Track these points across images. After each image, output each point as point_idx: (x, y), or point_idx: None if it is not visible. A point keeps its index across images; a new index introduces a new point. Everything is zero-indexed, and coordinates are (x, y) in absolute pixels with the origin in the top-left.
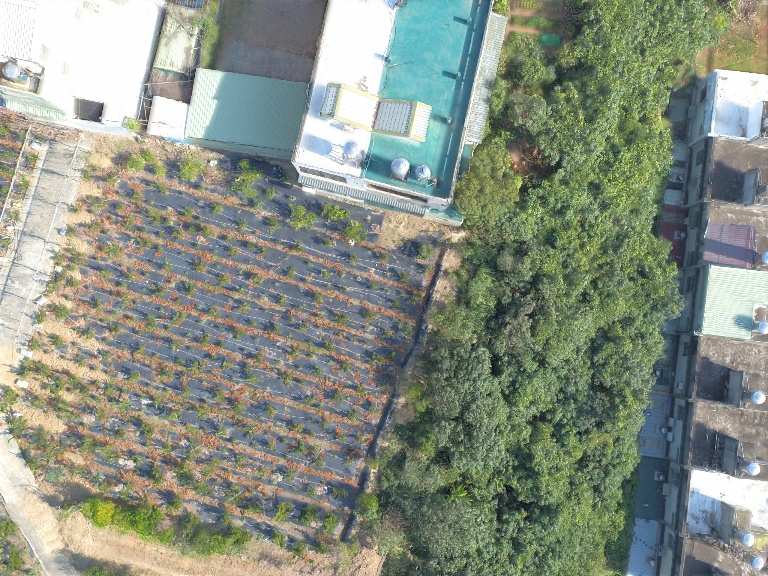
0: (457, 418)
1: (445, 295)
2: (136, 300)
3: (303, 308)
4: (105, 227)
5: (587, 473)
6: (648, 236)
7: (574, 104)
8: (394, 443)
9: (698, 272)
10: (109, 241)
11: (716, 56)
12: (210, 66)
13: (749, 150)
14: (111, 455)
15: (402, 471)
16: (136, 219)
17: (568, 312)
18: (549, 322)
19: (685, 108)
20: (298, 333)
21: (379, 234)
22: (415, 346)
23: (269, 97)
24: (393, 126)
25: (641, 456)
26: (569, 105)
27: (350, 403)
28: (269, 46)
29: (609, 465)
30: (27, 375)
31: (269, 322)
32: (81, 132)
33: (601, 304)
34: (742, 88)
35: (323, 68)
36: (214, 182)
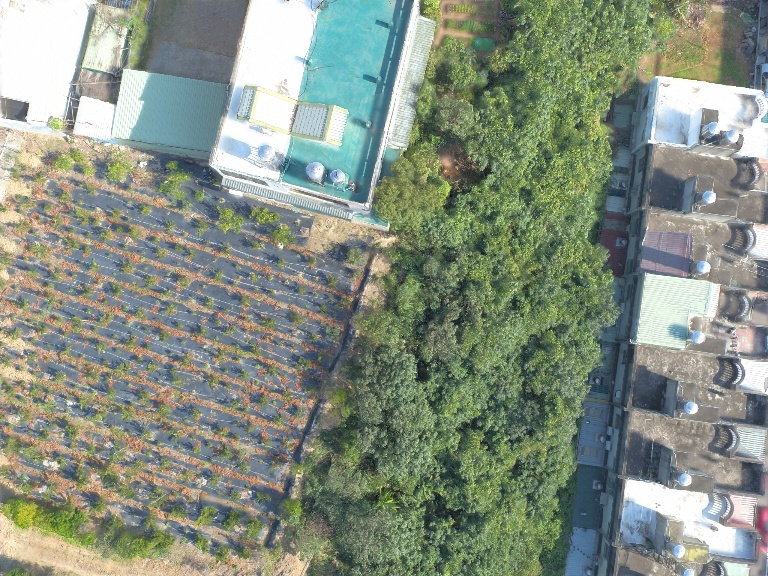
0: (382, 424)
1: (371, 300)
2: (63, 301)
3: (230, 311)
4: (34, 227)
5: (521, 481)
6: (584, 243)
7: (504, 109)
8: (318, 448)
9: (636, 280)
10: (37, 241)
11: (664, 62)
12: (141, 67)
13: (690, 158)
14: (35, 456)
15: (327, 477)
16: (65, 219)
17: (497, 319)
18: (475, 329)
19: (630, 114)
20: (225, 336)
21: (308, 238)
22: (342, 351)
23: (196, 99)
24: (310, 130)
25: (580, 464)
26: (499, 110)
27: (276, 407)
28: (201, 47)
29: (543, 473)
30: None
31: (196, 325)
32: (12, 132)
33: (532, 311)
34: (684, 95)
35: (244, 70)
36: (144, 183)
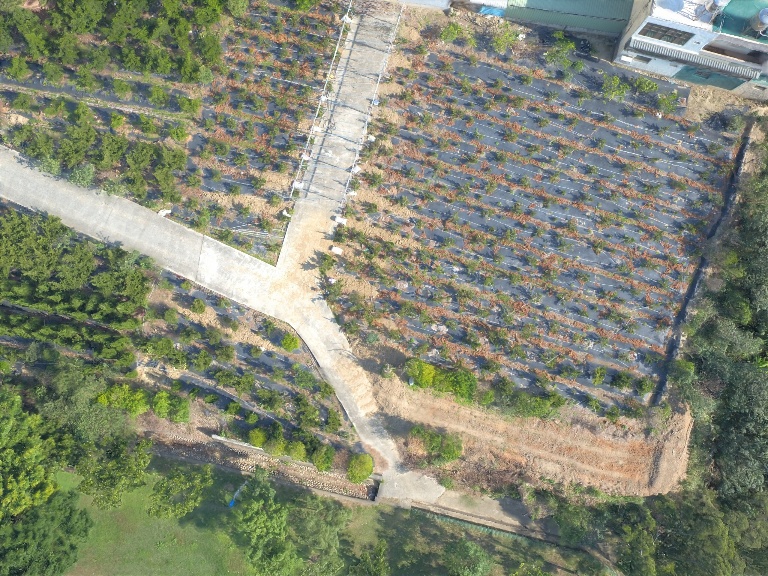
0: None
1: (761, 163)
2: (447, 170)
3: (613, 179)
4: (416, 99)
5: None
6: None
7: None
8: (710, 308)
9: None
10: (420, 112)
11: None
12: None
13: None
14: (425, 320)
15: (712, 338)
16: (447, 91)
17: None
18: None
19: None
20: (608, 203)
21: (686, 107)
22: (723, 217)
23: None
24: None
25: None
26: None
27: (659, 272)
28: None
29: None
30: None
31: (579, 192)
32: (391, 6)
33: None
34: None
35: None
36: (523, 55)
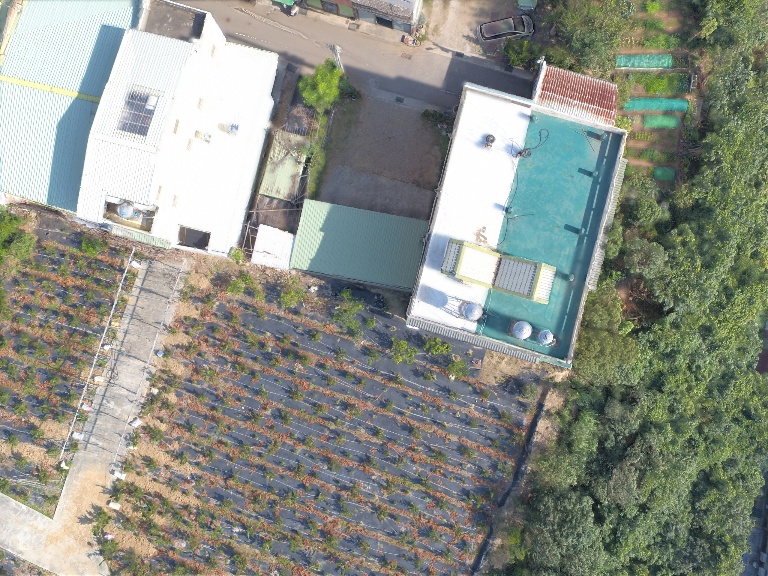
0: (555, 566)
1: (549, 440)
2: (231, 426)
3: (400, 442)
4: (202, 350)
5: None
6: (754, 374)
7: (690, 248)
8: None
9: None
10: (206, 364)
11: None
12: (315, 191)
13: None
14: None
15: None
16: (234, 343)
17: (673, 459)
18: (656, 473)
19: None
20: (394, 468)
21: (481, 369)
22: (513, 487)
23: (377, 232)
24: (515, 286)
25: None
26: (685, 248)
27: (444, 542)
28: (375, 172)
29: None
30: (120, 497)
31: (365, 455)
32: (181, 252)
33: (706, 449)
34: None
35: (441, 216)
36: (314, 309)
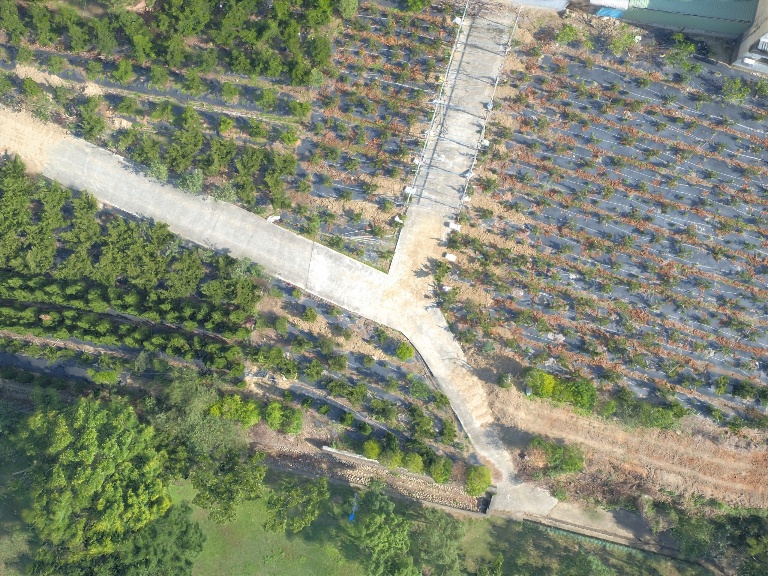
0: None
1: None
2: (563, 175)
3: (732, 183)
4: (530, 102)
5: None
6: None
7: None
8: None
9: None
10: (535, 116)
11: None
12: None
13: None
14: (542, 328)
15: None
16: (562, 94)
17: None
18: None
19: None
20: (727, 208)
21: None
22: None
23: None
24: None
25: None
26: None
27: None
28: None
29: None
30: None
31: (698, 197)
32: (504, 8)
33: None
34: None
35: None
36: (639, 58)
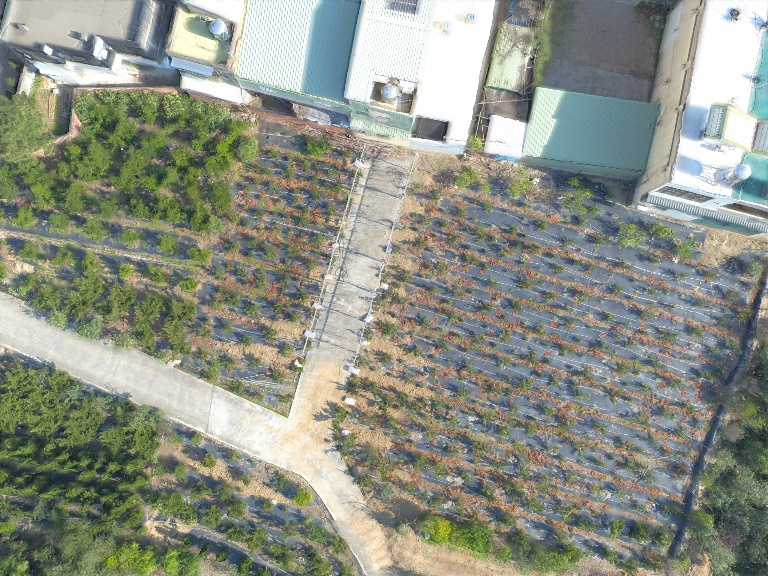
0: None
1: None
2: (461, 317)
3: (629, 326)
4: (429, 245)
5: None
6: None
7: None
8: (729, 461)
9: None
10: (433, 259)
11: None
12: None
13: None
14: (441, 472)
15: (731, 488)
16: (460, 237)
17: None
18: None
19: None
20: (624, 351)
21: (702, 252)
22: (741, 364)
23: (608, 116)
24: None
25: None
26: None
27: (677, 420)
28: (592, 65)
29: None
30: None
31: (595, 340)
32: (403, 150)
33: None
34: None
35: (691, 89)
36: (537, 200)
